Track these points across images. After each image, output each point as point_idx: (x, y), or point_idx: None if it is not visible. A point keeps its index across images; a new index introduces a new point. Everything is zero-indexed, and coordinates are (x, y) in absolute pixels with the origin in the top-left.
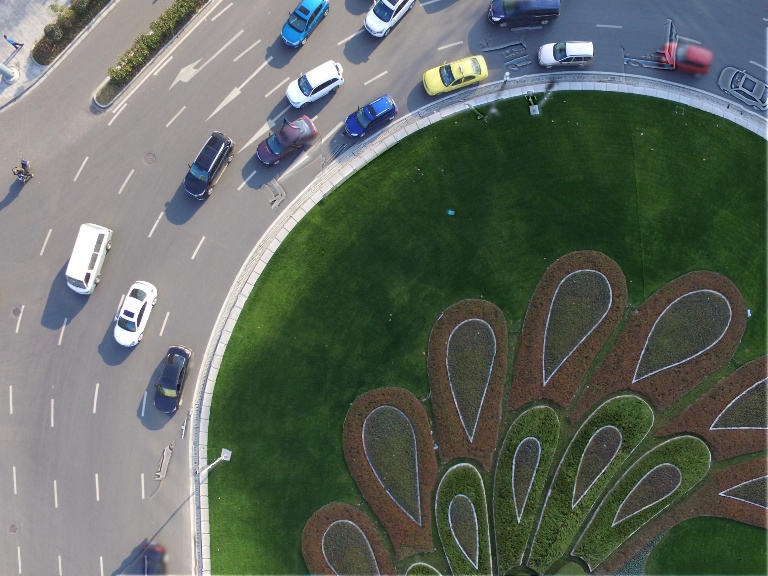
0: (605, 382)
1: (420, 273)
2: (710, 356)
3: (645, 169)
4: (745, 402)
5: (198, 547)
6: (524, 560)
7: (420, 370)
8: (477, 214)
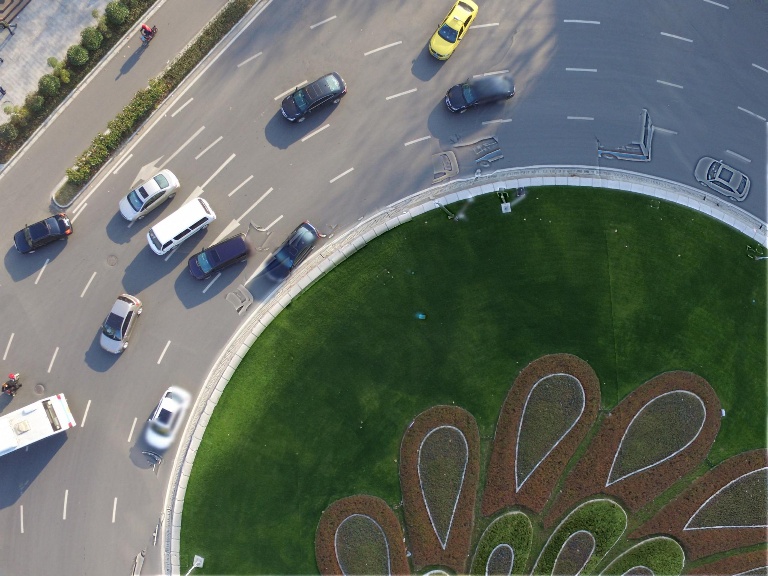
0: (578, 487)
1: (391, 379)
2: (684, 457)
3: (619, 267)
4: (719, 502)
5: None
6: None
7: (392, 477)
8: (448, 318)
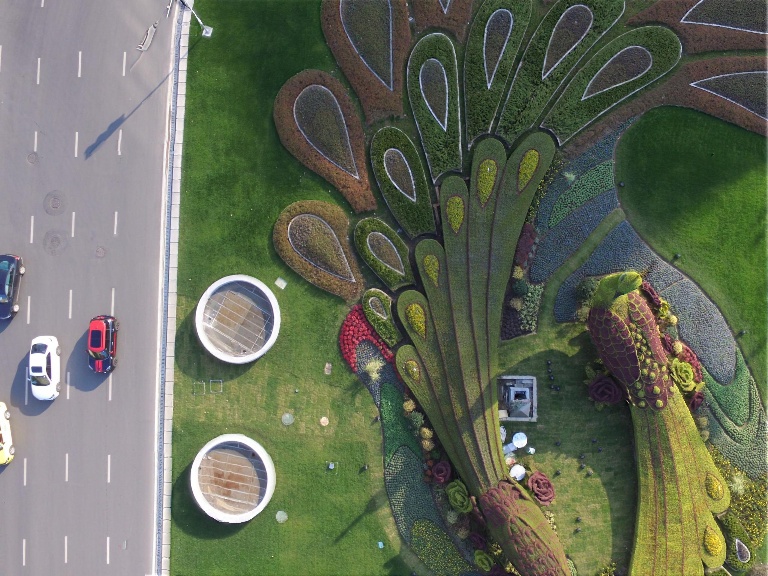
0: None
1: None
2: None
3: None
4: None
5: (172, 117)
6: (493, 130)
7: None
8: None
